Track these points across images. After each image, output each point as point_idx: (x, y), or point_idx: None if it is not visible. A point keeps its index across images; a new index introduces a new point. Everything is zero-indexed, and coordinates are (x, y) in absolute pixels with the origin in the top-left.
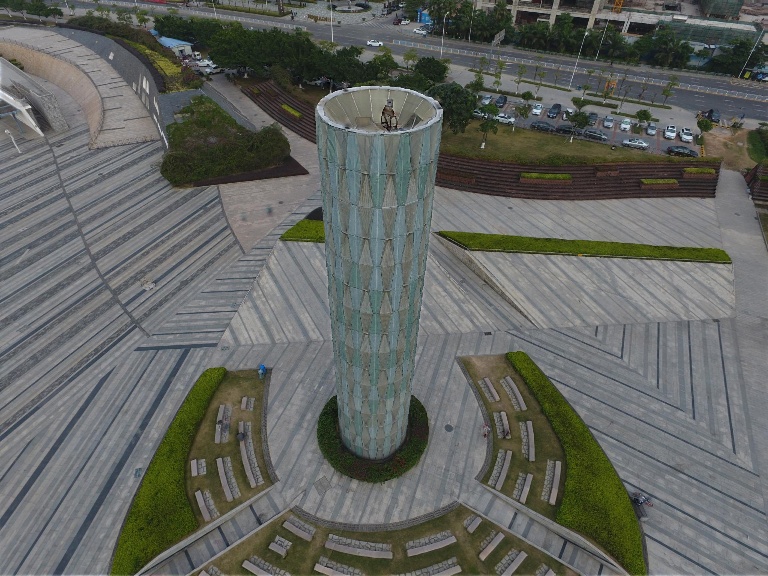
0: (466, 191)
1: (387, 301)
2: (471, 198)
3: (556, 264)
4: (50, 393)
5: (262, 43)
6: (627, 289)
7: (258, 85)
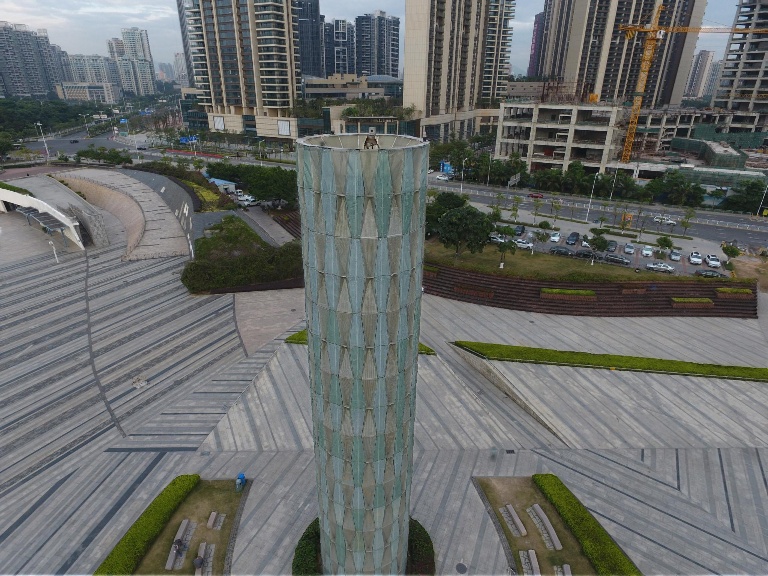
0: (484, 305)
1: (371, 363)
2: (490, 312)
3: (586, 377)
4: None
5: None
6: (673, 408)
7: (289, 214)
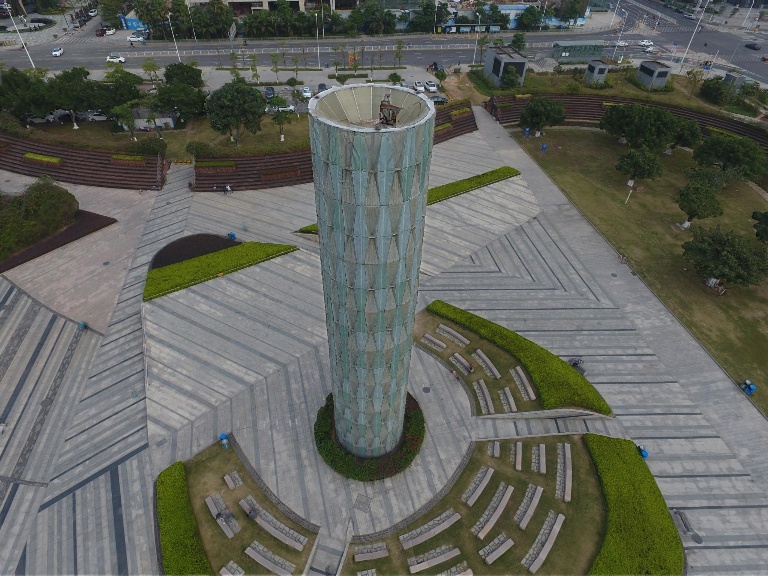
0: (296, 184)
1: (407, 289)
2: (305, 189)
3: None
4: None
5: None
6: (472, 219)
7: None
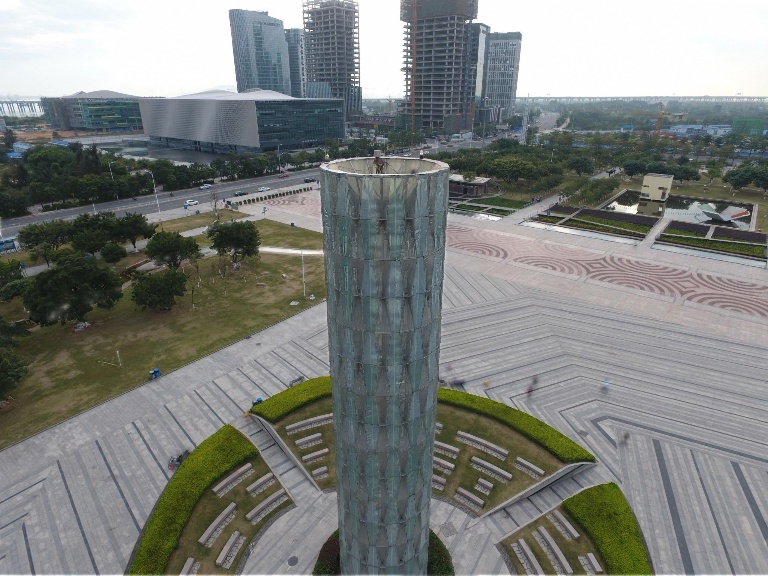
0: None
1: None
2: None
3: None
4: None
5: None
6: None
7: None
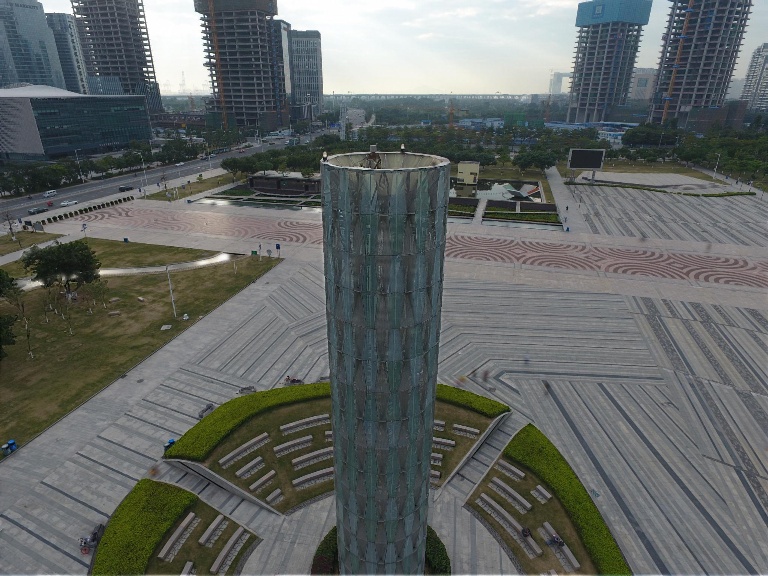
0: None
1: None
2: None
3: None
4: None
5: None
6: None
7: None
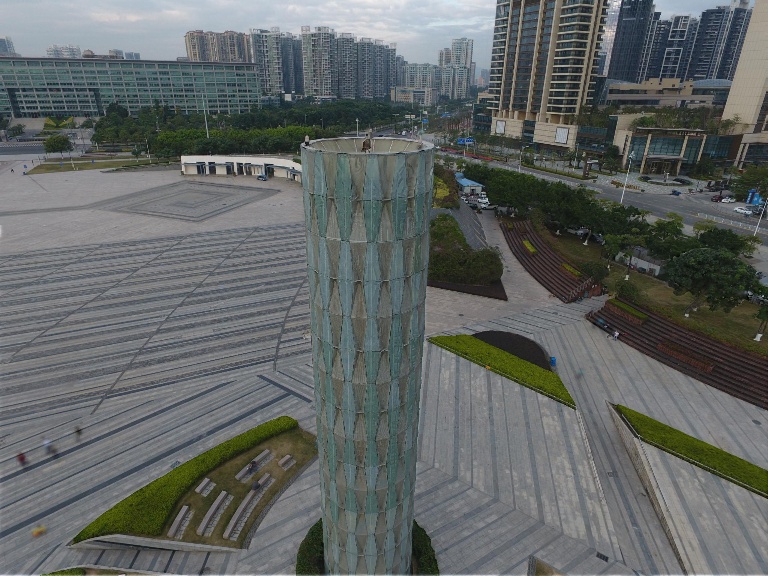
0: (693, 378)
1: (339, 363)
2: (696, 388)
3: None
4: (189, 377)
5: (532, 188)
6: None
7: (515, 222)
